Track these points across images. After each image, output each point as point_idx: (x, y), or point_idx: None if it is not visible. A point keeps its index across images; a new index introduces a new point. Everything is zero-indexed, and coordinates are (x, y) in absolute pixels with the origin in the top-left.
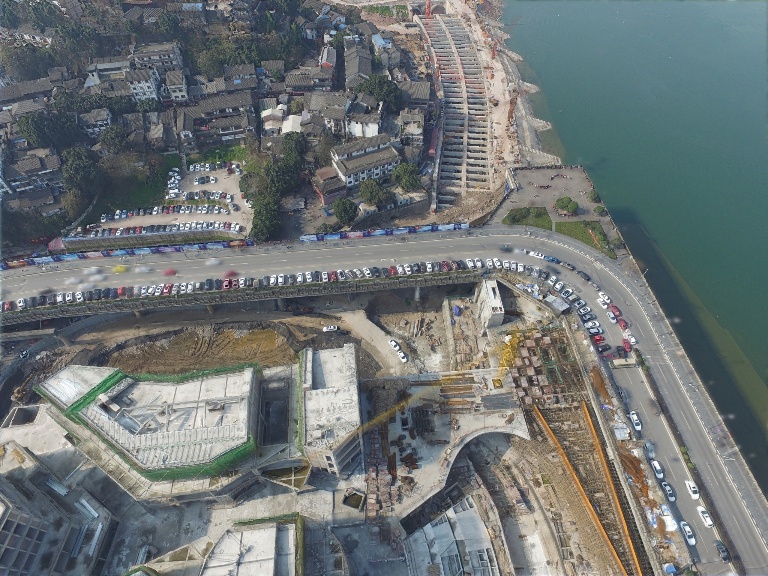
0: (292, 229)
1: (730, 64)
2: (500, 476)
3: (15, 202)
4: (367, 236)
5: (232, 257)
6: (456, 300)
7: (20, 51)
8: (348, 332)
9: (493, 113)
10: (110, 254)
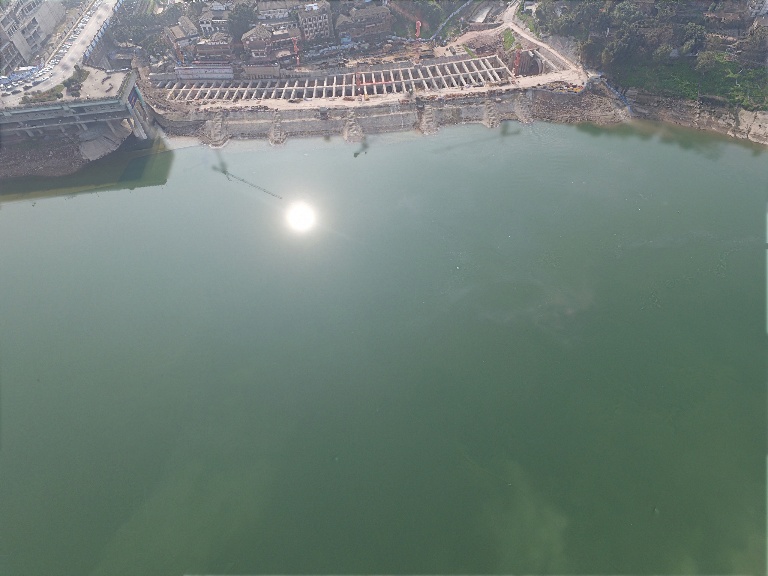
0: None
1: (450, 346)
2: None
3: None
4: None
5: None
6: None
7: None
8: None
9: (277, 100)
10: None
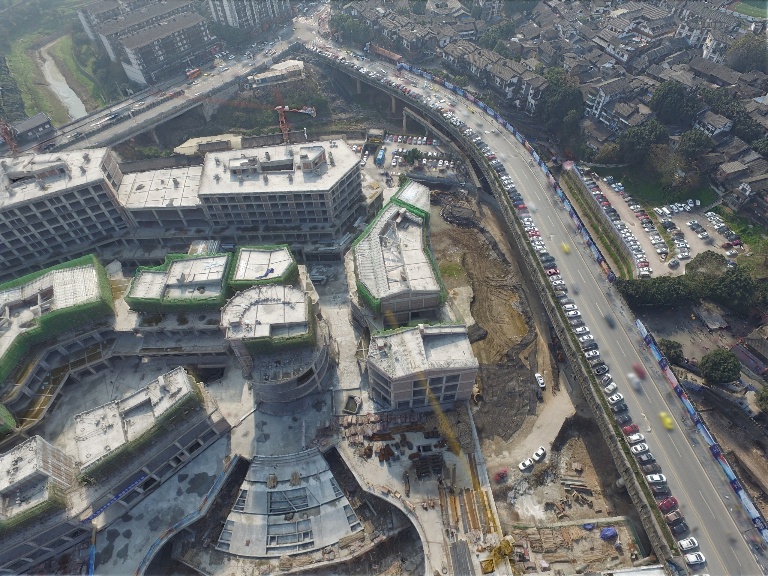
0: (669, 323)
1: None
2: (387, 572)
3: (589, 123)
4: (677, 393)
5: (588, 269)
6: (629, 534)
7: (756, 44)
8: (541, 399)
9: None
10: (557, 188)
